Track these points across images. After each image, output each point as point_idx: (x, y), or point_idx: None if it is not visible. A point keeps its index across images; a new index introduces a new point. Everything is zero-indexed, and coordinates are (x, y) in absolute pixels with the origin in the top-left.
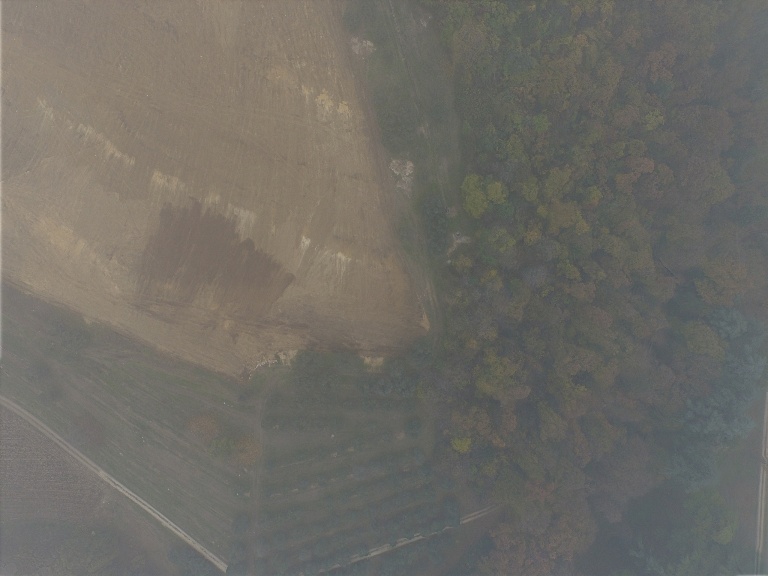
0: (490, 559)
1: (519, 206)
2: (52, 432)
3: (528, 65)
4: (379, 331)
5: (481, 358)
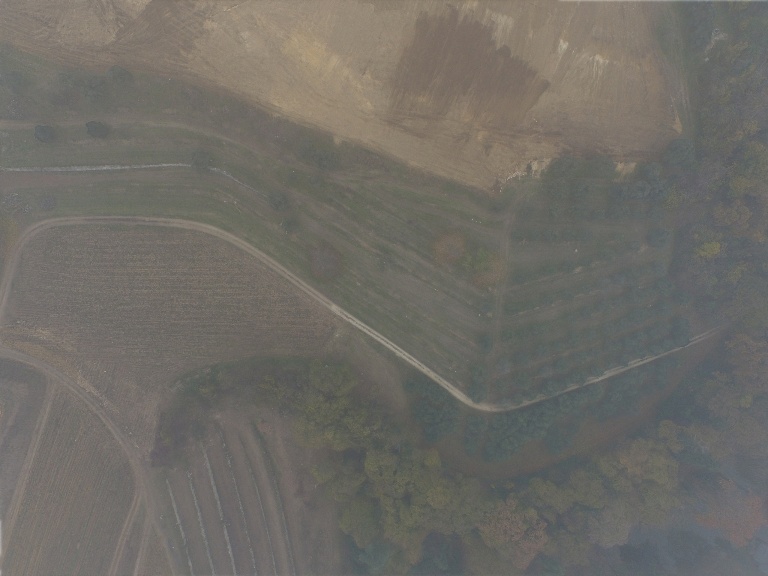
0: (722, 374)
1: None
2: (283, 269)
3: None
4: (632, 136)
5: (740, 154)
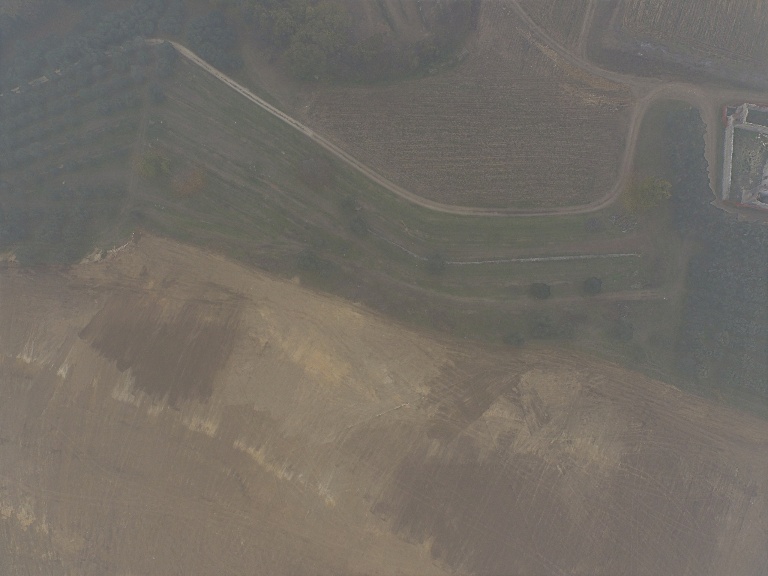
0: None
1: None
2: (360, 169)
3: None
4: None
5: None
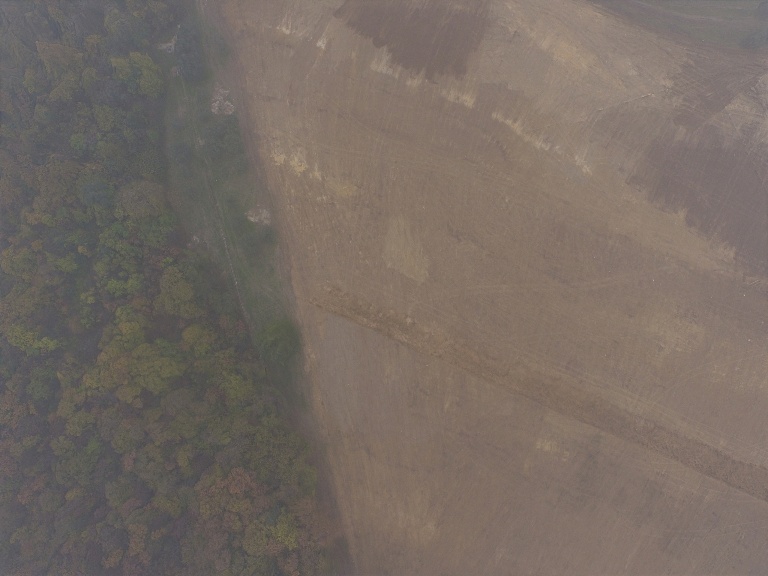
0: None
1: (103, 65)
2: None
3: (85, 186)
4: None
5: None
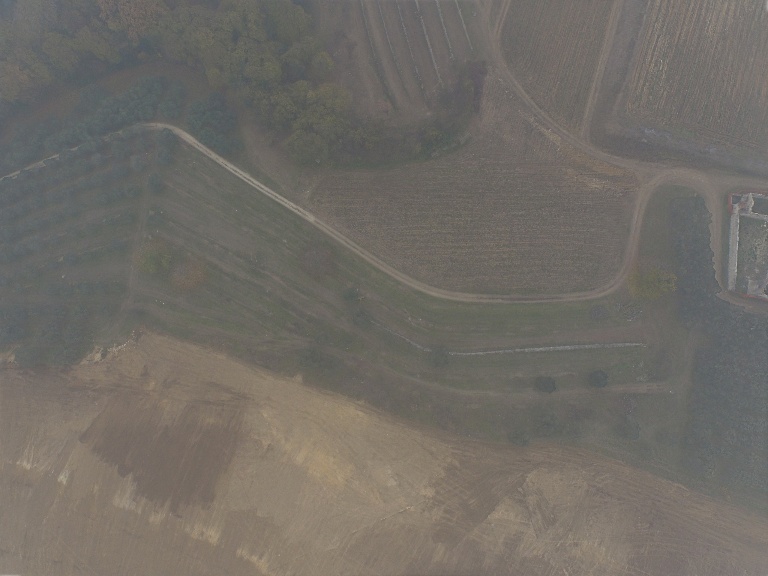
0: None
1: None
2: (363, 256)
3: None
4: None
5: None
